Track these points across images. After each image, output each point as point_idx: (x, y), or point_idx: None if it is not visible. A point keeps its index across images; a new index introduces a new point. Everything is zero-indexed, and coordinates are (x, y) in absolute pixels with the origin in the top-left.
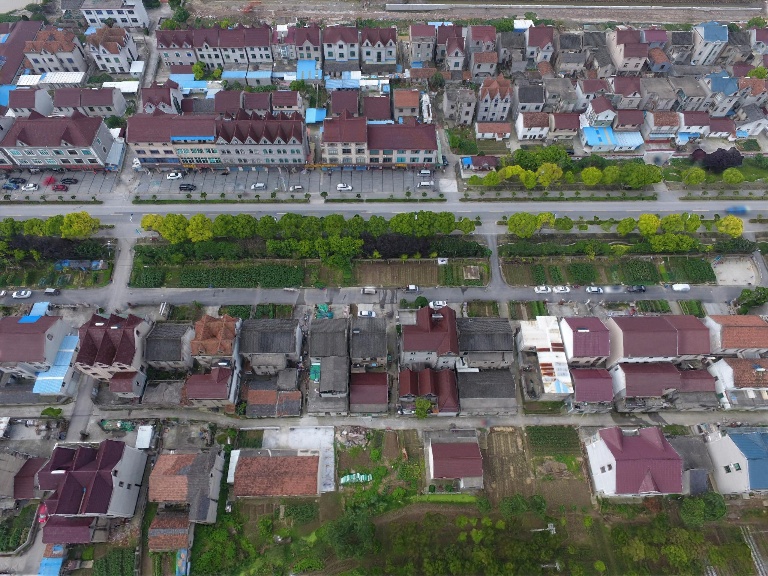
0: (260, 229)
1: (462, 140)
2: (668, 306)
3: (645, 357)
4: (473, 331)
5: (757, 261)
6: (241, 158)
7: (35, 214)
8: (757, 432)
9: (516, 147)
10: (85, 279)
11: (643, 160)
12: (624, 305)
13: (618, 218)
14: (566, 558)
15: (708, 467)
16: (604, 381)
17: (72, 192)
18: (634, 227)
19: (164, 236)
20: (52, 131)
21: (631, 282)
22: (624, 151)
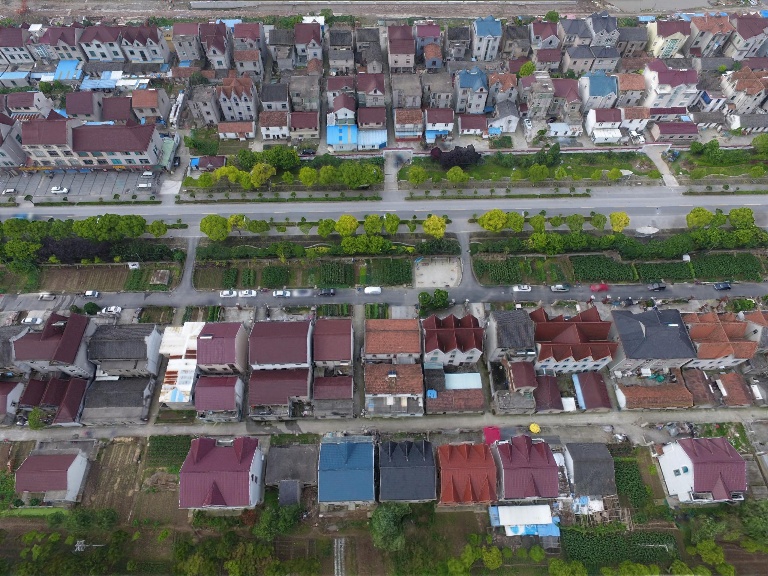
0: None
1: None
2: (351, 310)
3: (275, 364)
4: (106, 338)
5: (464, 262)
6: None
7: None
8: (345, 442)
9: (258, 147)
10: None
11: (383, 159)
12: (306, 309)
13: (333, 219)
14: (123, 575)
15: (310, 478)
16: (226, 389)
17: None
18: (331, 228)
19: None
20: None
21: (323, 285)
22: (368, 150)
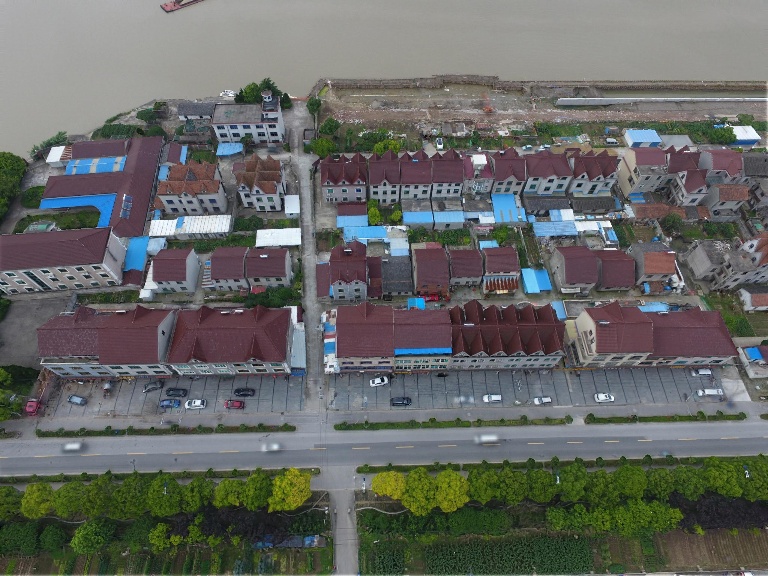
0: (538, 496)
1: None
2: None
3: None
4: None
5: None
6: (474, 365)
7: (210, 450)
8: None
9: None
10: (296, 562)
11: None
12: None
13: None
14: None
15: None
16: None
17: (251, 410)
18: None
19: (407, 507)
20: (234, 341)
21: None
22: None
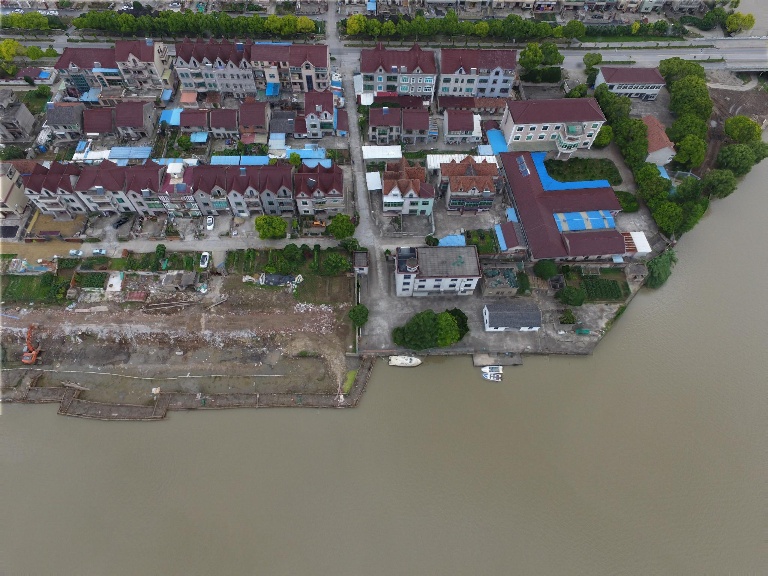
0: None
1: (36, 92)
2: None
3: None
4: None
5: None
6: None
7: None
8: None
9: None
10: None
11: None
12: None
13: None
14: None
15: None
16: None
17: None
18: None
19: None
20: None
21: None
22: None
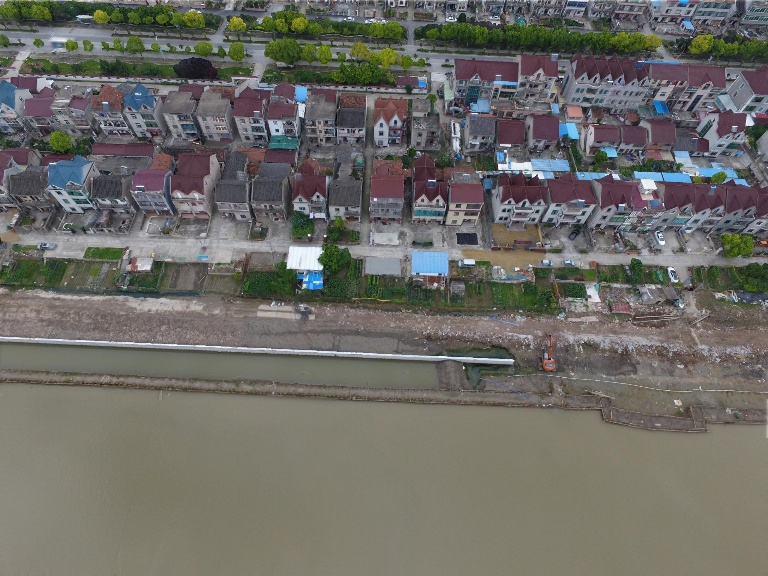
0: None
1: None
2: None
3: None
4: None
5: None
6: None
7: None
8: None
9: (371, 103)
10: None
11: None
12: None
13: None
14: None
15: None
16: None
17: None
18: None
19: None
20: None
21: None
22: None
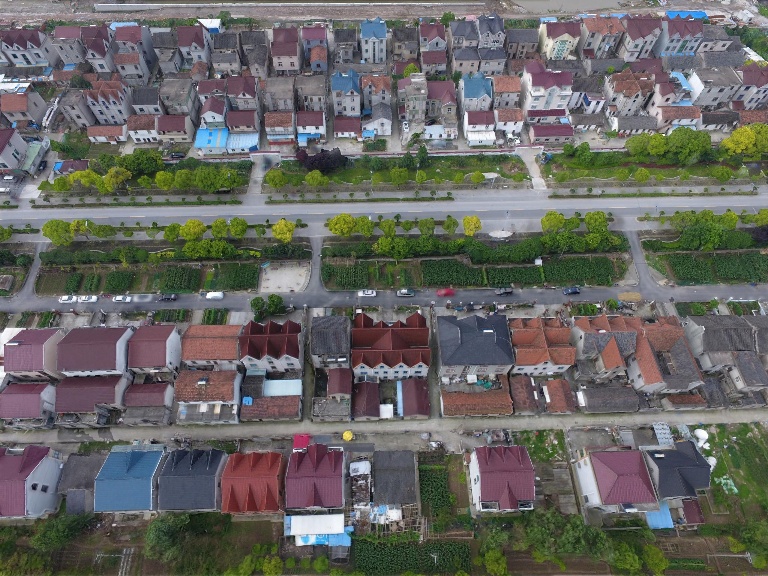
0: None
1: (67, 144)
2: (189, 315)
3: (84, 371)
4: None
5: (314, 267)
6: None
7: None
8: None
9: (129, 151)
10: None
11: (251, 162)
12: (144, 315)
13: None
14: None
15: None
16: (31, 396)
17: None
18: (177, 233)
19: None
20: None
21: (166, 290)
22: (238, 153)
